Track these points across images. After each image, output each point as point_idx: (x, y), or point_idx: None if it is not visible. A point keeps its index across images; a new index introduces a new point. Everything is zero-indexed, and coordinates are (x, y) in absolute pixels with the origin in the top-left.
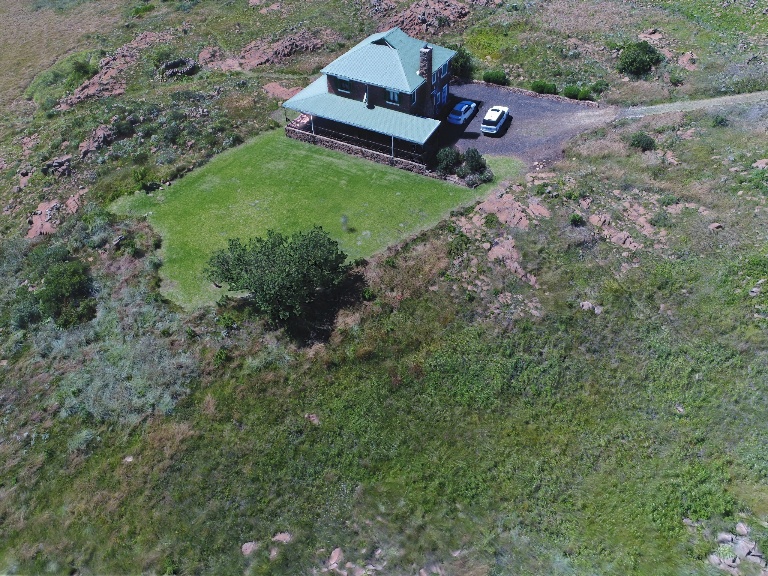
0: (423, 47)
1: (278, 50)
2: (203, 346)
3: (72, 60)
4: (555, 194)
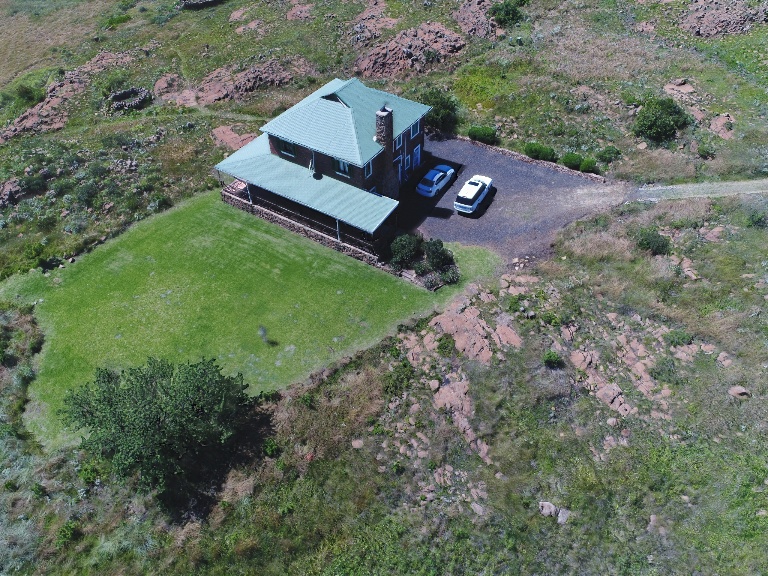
0: (380, 109)
1: (239, 84)
2: (50, 512)
3: (28, 79)
4: (531, 315)
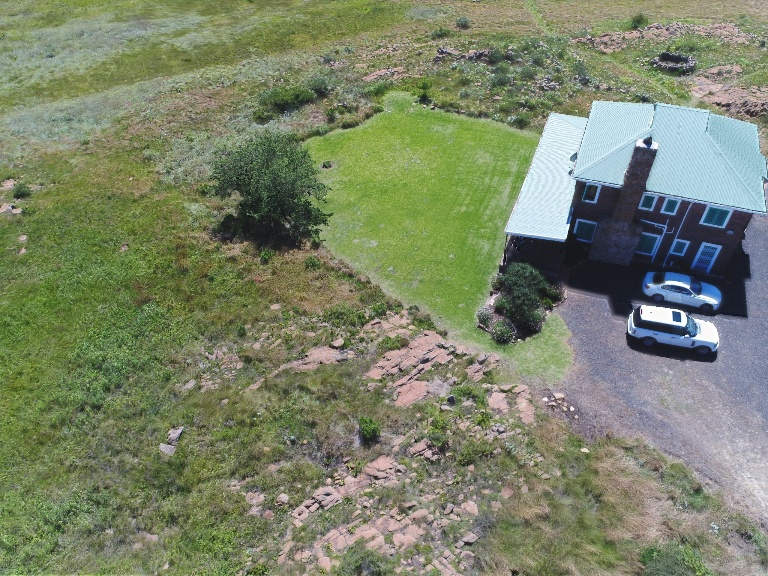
0: None
1: (750, 102)
2: None
3: None
4: None
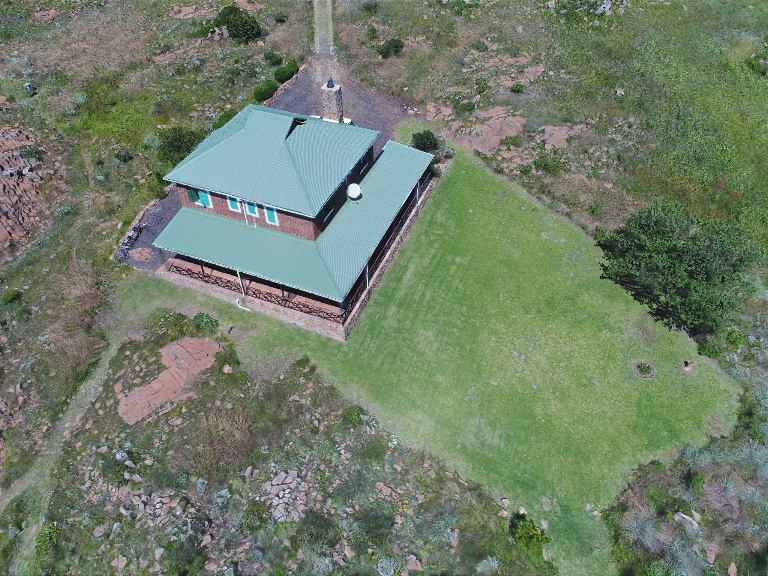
0: (332, 86)
1: None
2: None
3: None
4: None
